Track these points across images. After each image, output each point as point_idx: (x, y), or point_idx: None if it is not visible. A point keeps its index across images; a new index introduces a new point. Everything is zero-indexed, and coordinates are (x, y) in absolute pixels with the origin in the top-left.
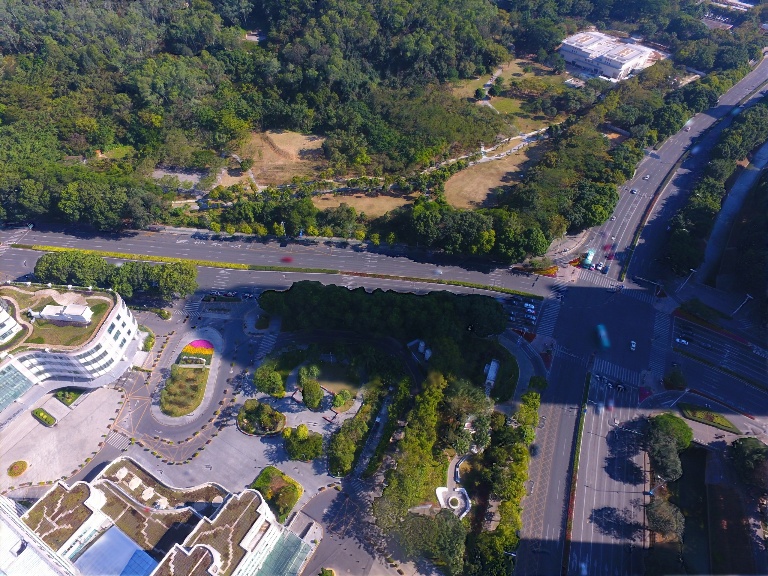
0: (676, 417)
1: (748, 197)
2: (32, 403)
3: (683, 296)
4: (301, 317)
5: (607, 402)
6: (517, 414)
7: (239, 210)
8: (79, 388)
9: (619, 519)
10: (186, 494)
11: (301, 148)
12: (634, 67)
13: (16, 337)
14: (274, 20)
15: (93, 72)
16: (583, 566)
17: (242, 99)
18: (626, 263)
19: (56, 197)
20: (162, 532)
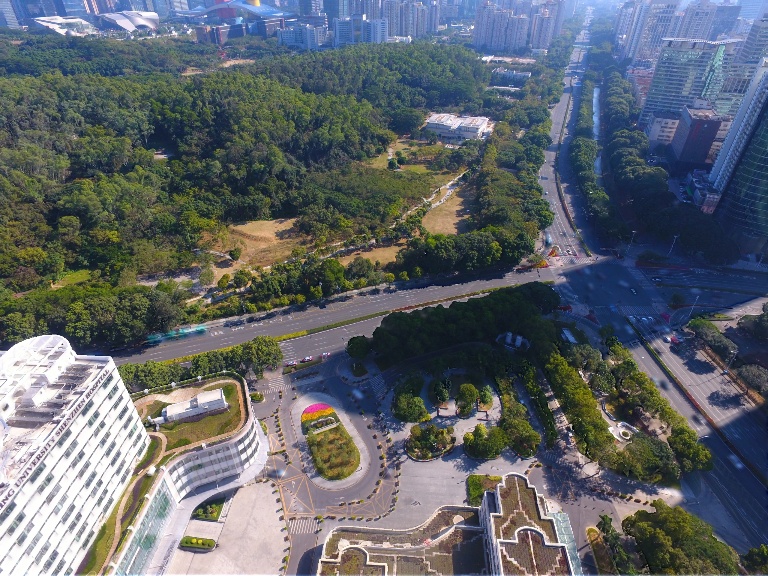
0: (700, 320)
1: (611, 192)
2: (182, 529)
3: (632, 254)
4: (413, 341)
5: (652, 330)
6: (613, 356)
7: (267, 286)
8: (217, 498)
9: (725, 396)
10: (425, 530)
11: (275, 231)
12: (483, 131)
13: (151, 450)
14: (179, 137)
15: (6, 207)
16: (734, 435)
17: (198, 200)
18: (583, 245)
19: (59, 323)
20: (449, 560)
